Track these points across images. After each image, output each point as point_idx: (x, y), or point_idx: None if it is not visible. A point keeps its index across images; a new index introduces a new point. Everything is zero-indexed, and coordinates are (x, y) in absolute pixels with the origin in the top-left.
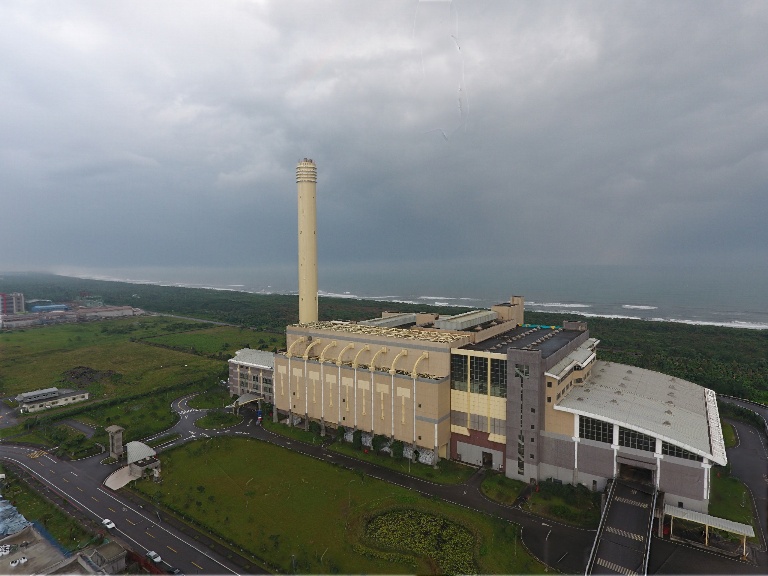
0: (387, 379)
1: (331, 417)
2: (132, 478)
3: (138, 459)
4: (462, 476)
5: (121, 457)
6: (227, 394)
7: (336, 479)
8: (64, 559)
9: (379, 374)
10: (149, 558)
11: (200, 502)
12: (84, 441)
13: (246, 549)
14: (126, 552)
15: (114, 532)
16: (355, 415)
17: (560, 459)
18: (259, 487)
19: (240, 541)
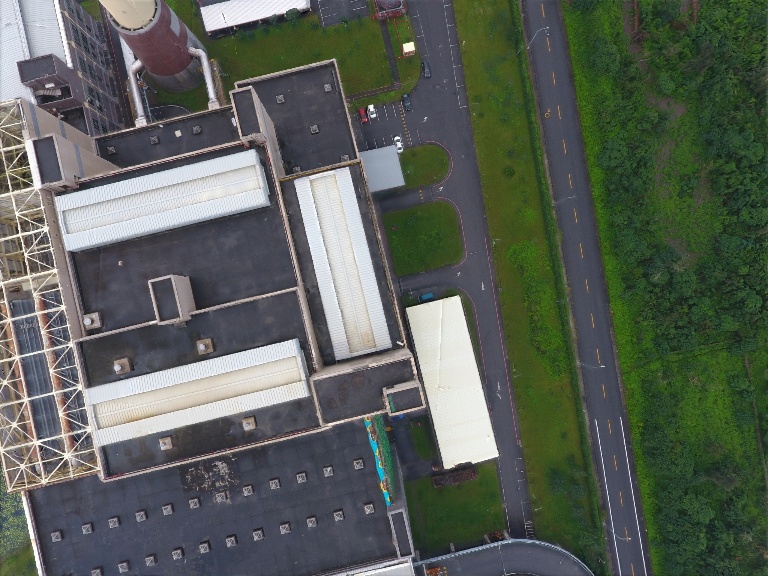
0: None
1: None
2: None
3: None
4: None
5: None
6: None
7: None
8: None
9: None
10: None
11: None
12: None
13: None
14: None
15: None
16: None
17: None
18: None
19: None
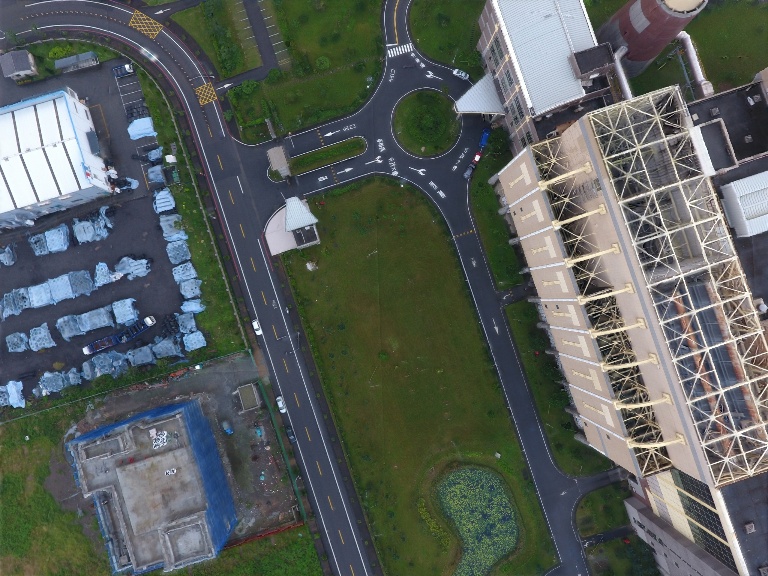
0: (606, 391)
1: (537, 284)
2: (291, 241)
3: (297, 227)
4: (586, 469)
5: (287, 182)
6: (480, 2)
7: (471, 385)
8: (198, 487)
9: (605, 378)
10: (277, 407)
11: (333, 354)
12: (256, 91)
13: (346, 442)
14: (258, 406)
15: (260, 341)
16: (556, 327)
17: (672, 567)
18: (396, 349)
19: (347, 426)
